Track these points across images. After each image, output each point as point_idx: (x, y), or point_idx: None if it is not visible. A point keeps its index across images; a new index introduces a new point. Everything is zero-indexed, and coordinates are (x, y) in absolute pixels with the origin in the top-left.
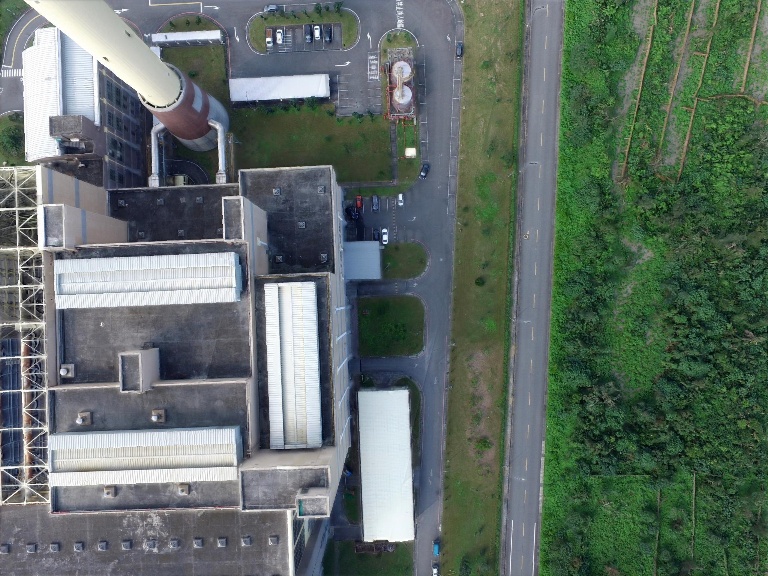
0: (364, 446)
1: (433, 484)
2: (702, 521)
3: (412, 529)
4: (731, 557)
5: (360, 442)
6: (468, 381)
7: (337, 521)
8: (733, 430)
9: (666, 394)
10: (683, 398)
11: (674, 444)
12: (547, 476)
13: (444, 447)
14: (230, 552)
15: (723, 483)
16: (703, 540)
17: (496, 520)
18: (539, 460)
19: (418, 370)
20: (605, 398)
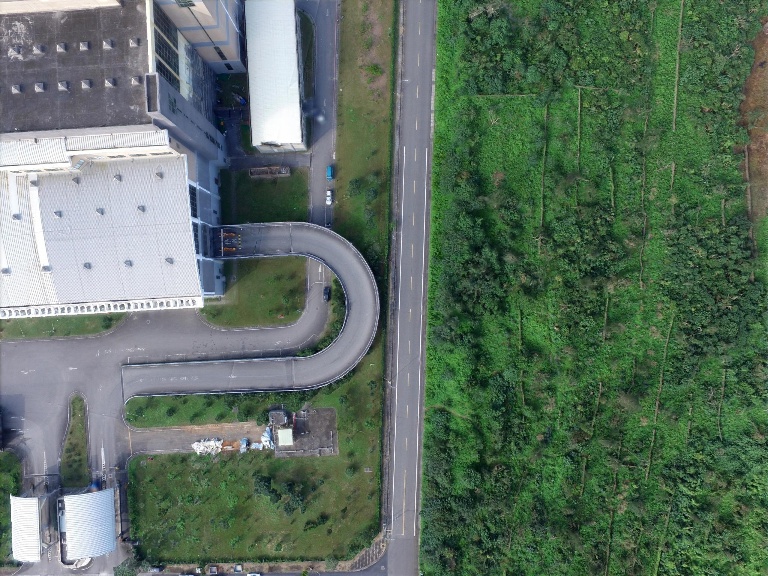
0: (251, 52)
1: (326, 113)
2: (588, 135)
3: (299, 131)
4: (618, 174)
5: (247, 49)
6: (359, 10)
7: (233, 152)
8: (615, 41)
9: (550, 12)
10: (567, 15)
11: (557, 55)
12: (437, 101)
13: (337, 77)
14: (93, 56)
15: (608, 99)
16: (589, 154)
17: (388, 145)
18: (430, 87)
19: (310, 3)
20: (489, 11)
